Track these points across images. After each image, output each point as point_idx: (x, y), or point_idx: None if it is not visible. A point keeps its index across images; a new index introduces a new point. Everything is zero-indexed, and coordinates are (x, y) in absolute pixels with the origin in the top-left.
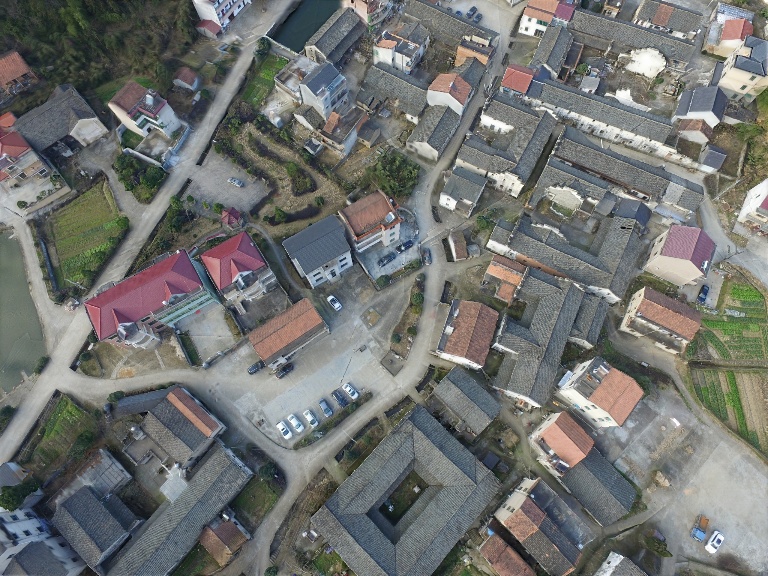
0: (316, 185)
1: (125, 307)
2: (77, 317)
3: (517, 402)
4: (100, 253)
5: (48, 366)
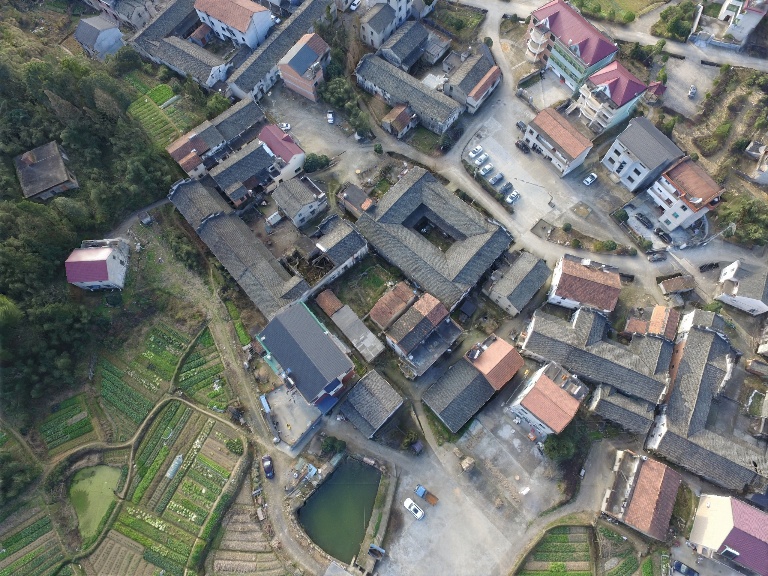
0: (710, 156)
1: (562, 19)
2: None
3: None
4: (599, 7)
5: (504, 2)
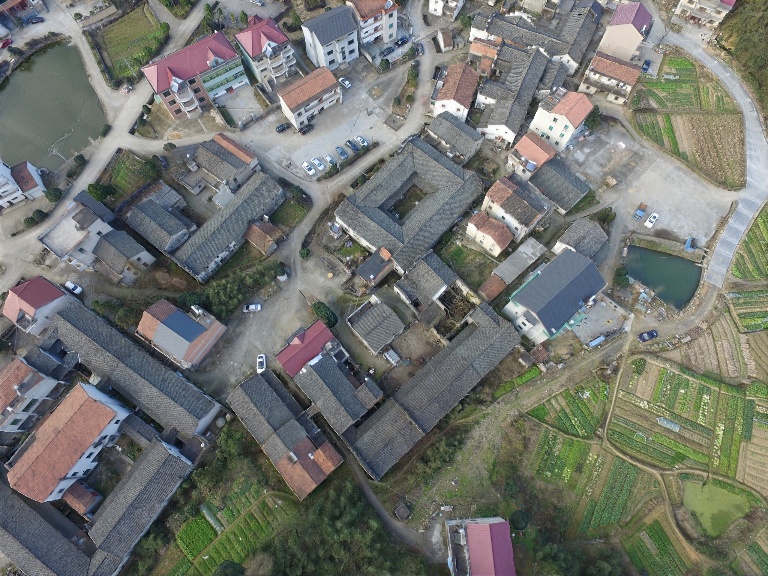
0: (325, 3)
1: (176, 67)
2: (131, 98)
3: (496, 142)
4: (148, 47)
5: (110, 132)
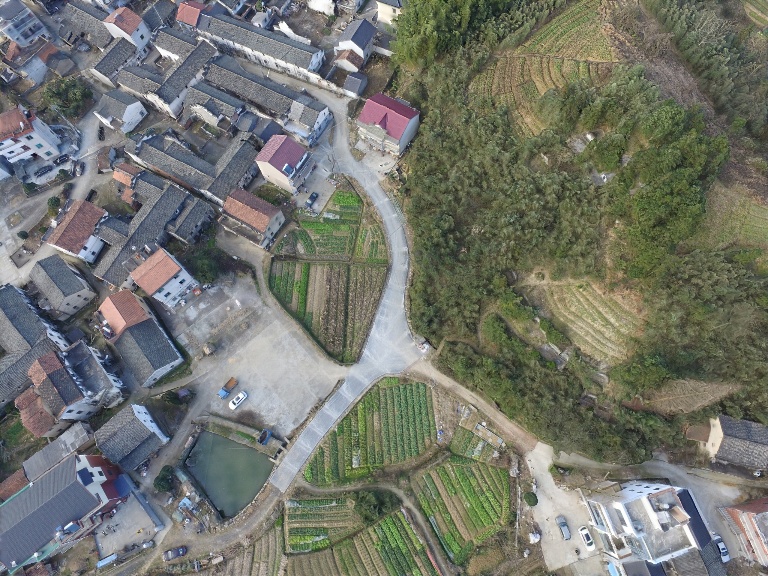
0: (2, 109)
1: None
2: None
3: None
4: None
5: None
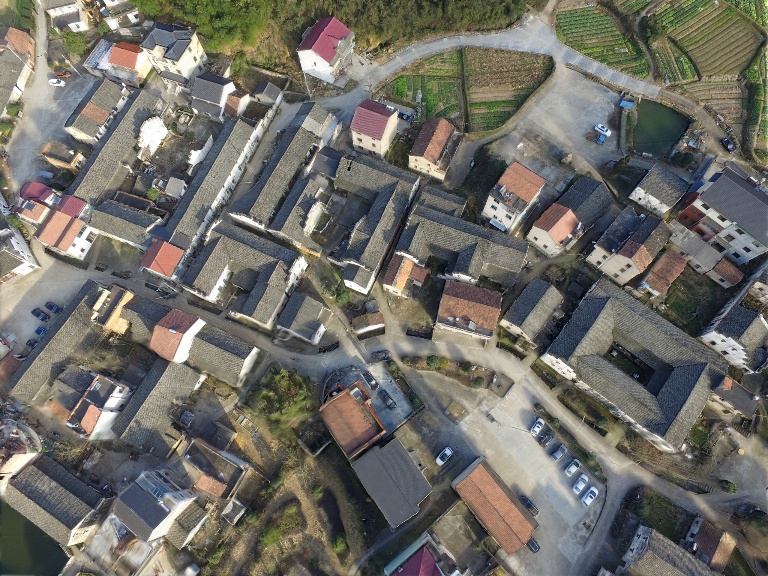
0: (291, 500)
1: None
2: None
3: (522, 266)
4: None
5: None
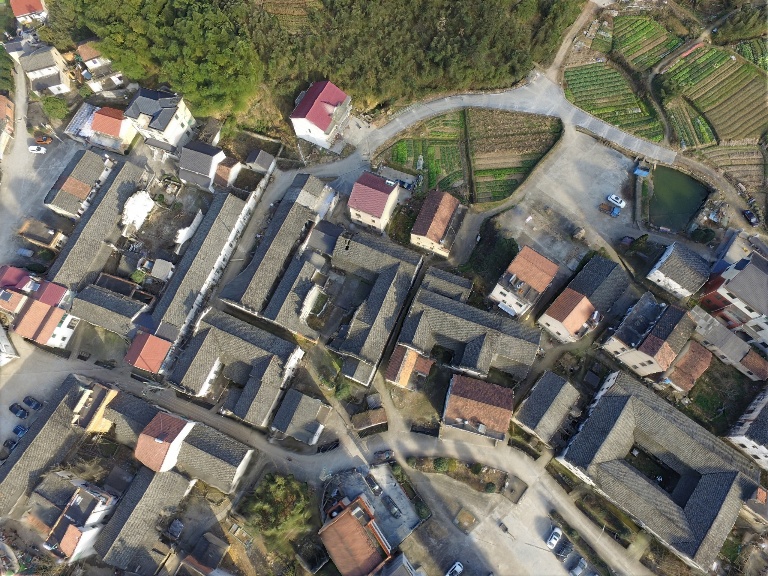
0: None
1: None
2: None
3: None
4: None
5: None
